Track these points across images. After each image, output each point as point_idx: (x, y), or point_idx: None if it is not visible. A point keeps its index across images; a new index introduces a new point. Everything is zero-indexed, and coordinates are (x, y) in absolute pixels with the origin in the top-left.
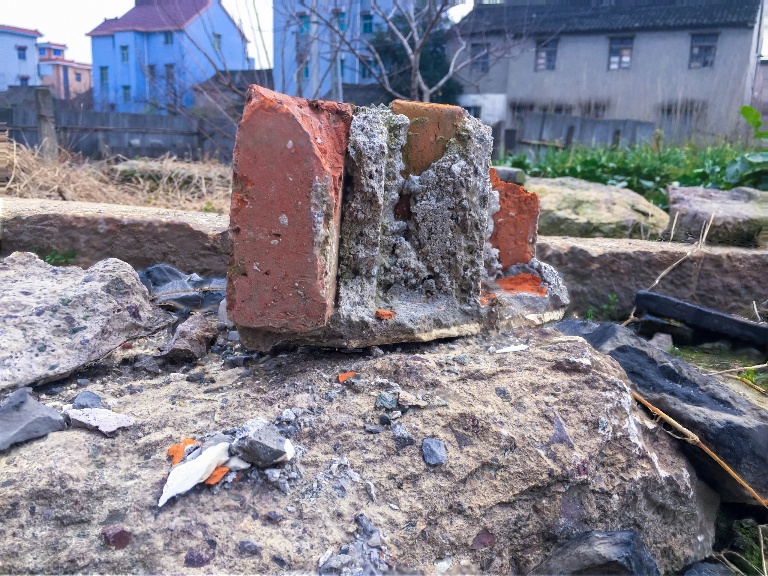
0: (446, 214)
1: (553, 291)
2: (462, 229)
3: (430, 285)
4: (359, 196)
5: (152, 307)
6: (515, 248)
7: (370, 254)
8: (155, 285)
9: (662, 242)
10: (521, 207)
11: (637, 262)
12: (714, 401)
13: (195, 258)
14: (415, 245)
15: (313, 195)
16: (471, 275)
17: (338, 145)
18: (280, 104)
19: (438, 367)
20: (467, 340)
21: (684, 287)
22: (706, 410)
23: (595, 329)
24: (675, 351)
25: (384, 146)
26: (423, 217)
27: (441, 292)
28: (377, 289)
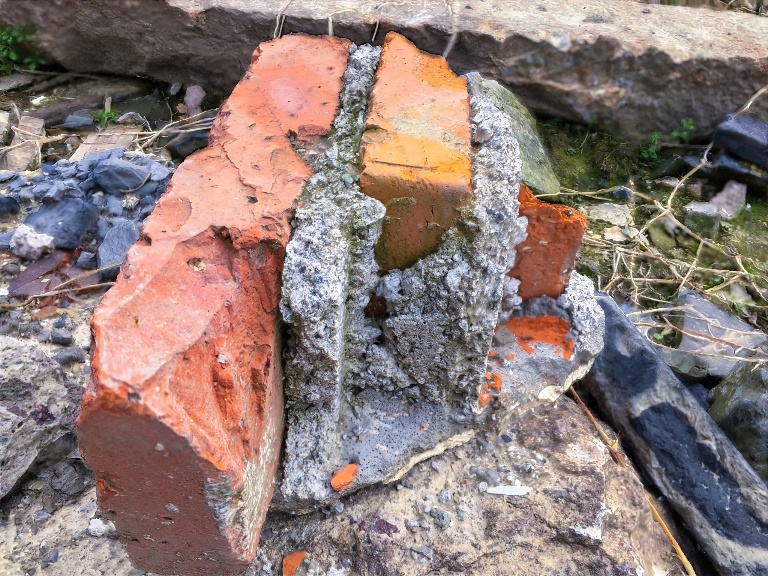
0: (436, 330)
1: (583, 345)
2: (459, 340)
3: (412, 394)
4: (303, 353)
5: (67, 388)
6: (542, 279)
7: (326, 394)
8: (107, 194)
9: None
10: (557, 235)
11: (731, 72)
12: (751, 521)
13: (178, 41)
14: (393, 354)
15: (207, 493)
16: (468, 383)
17: (265, 297)
18: (133, 398)
19: (409, 533)
20: (456, 451)
21: None
22: (737, 548)
23: (633, 351)
24: (745, 211)
25: (336, 298)
26: (403, 331)
27: (426, 401)
28: (344, 392)
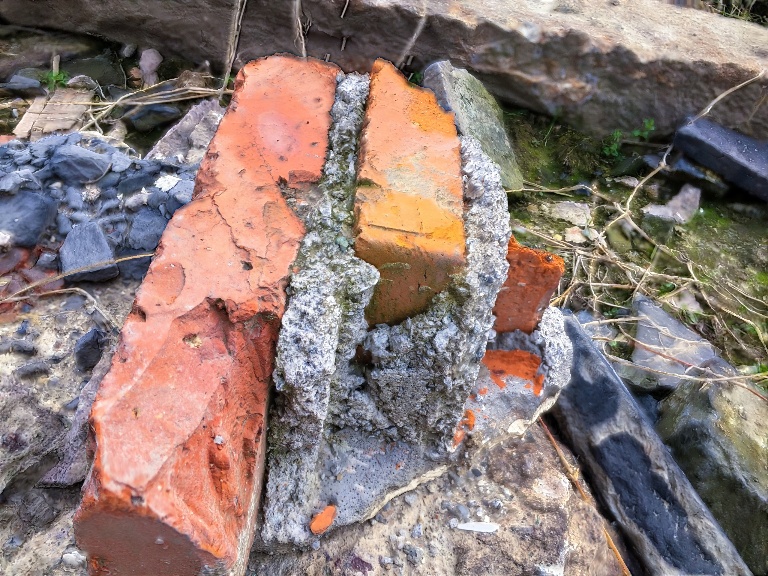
0: (420, 383)
1: (552, 379)
2: None
3: (390, 435)
4: (291, 413)
5: (36, 416)
6: (517, 315)
7: (309, 442)
8: (65, 185)
9: (738, 19)
10: (536, 278)
11: (694, 75)
12: (696, 549)
13: (134, 1)
14: (374, 400)
15: (203, 575)
16: (445, 425)
17: (258, 366)
18: (136, 501)
19: (383, 570)
20: (428, 485)
21: (740, 111)
22: (682, 575)
23: (596, 377)
24: (698, 215)
25: (330, 369)
26: (387, 382)
27: (403, 441)
28: None
